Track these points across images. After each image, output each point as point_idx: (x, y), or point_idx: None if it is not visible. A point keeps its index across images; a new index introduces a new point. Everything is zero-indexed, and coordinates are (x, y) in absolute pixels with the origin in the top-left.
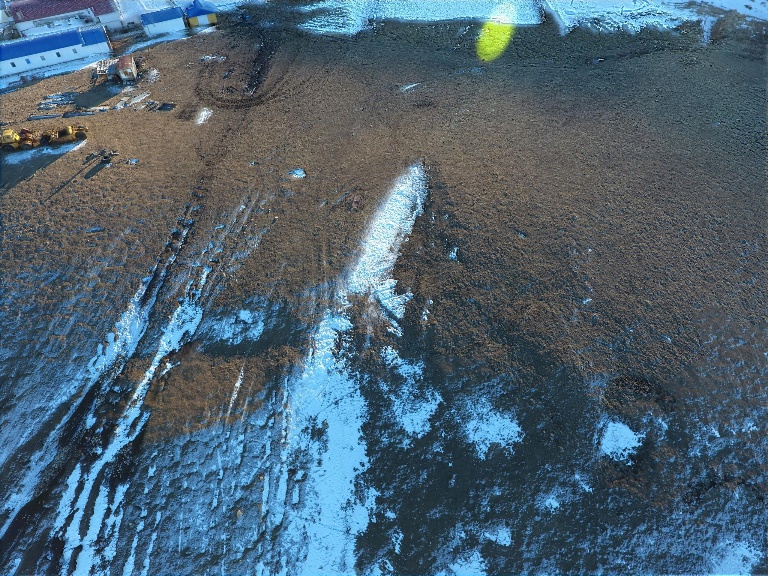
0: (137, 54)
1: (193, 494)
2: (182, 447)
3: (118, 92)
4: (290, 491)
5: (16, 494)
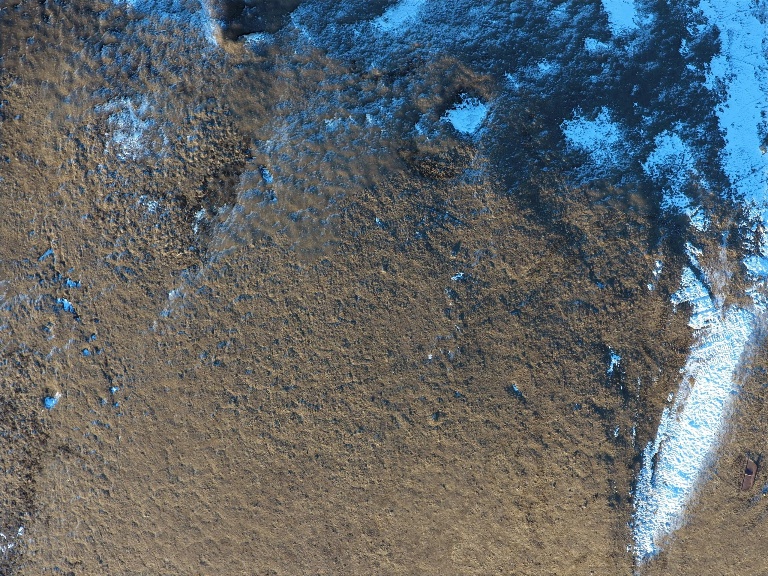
0: None
1: None
2: None
3: None
4: None
5: None
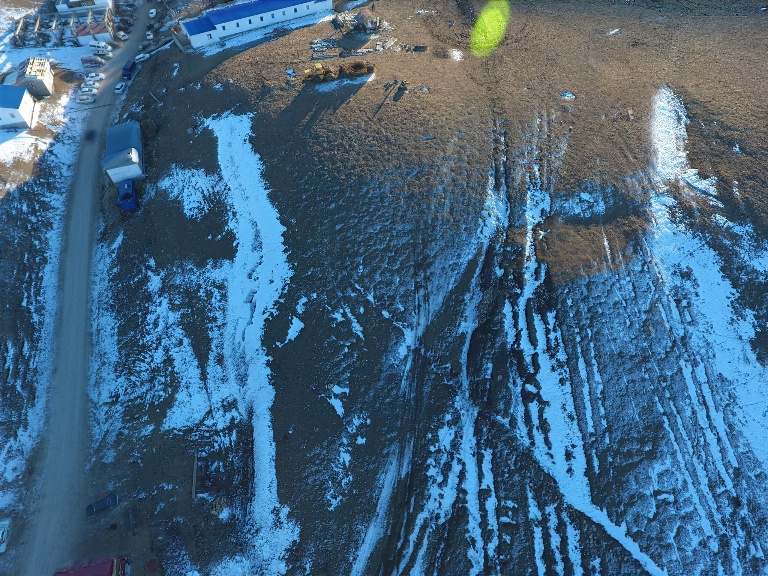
0: (358, 10)
1: (609, 316)
2: (586, 285)
3: (368, 39)
4: (682, 313)
5: (464, 322)
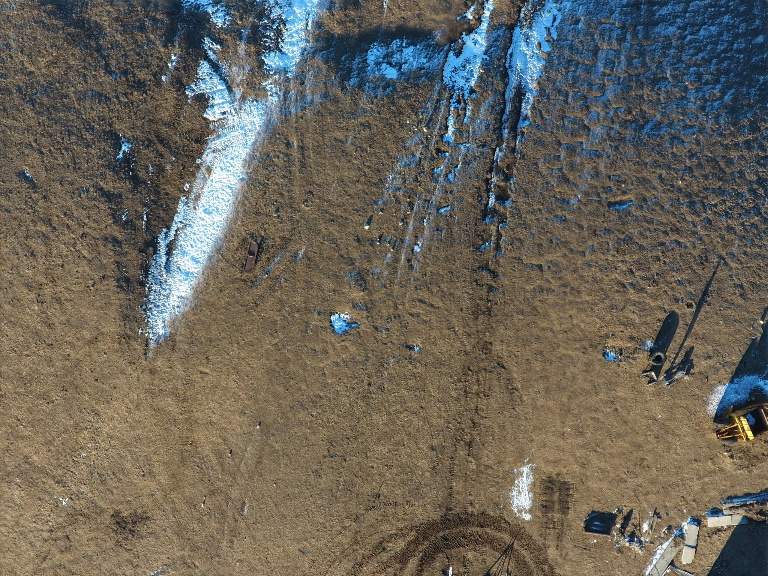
0: None
1: None
2: None
3: None
4: None
5: None
